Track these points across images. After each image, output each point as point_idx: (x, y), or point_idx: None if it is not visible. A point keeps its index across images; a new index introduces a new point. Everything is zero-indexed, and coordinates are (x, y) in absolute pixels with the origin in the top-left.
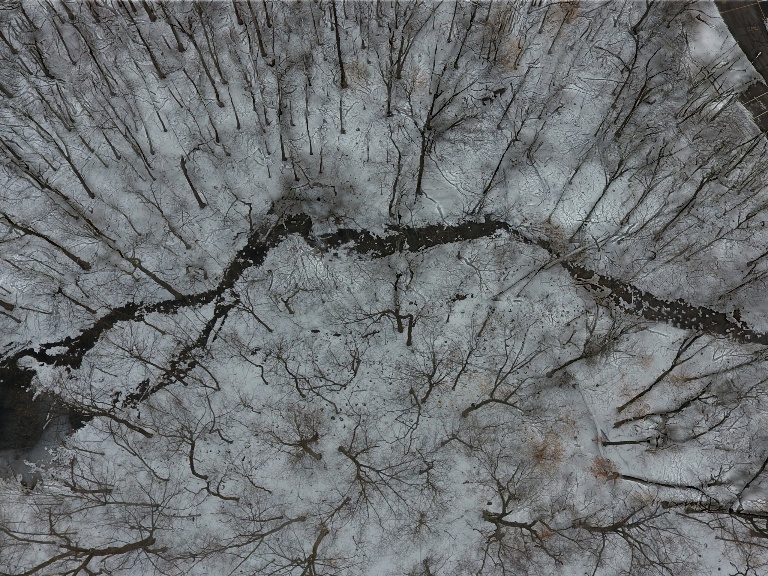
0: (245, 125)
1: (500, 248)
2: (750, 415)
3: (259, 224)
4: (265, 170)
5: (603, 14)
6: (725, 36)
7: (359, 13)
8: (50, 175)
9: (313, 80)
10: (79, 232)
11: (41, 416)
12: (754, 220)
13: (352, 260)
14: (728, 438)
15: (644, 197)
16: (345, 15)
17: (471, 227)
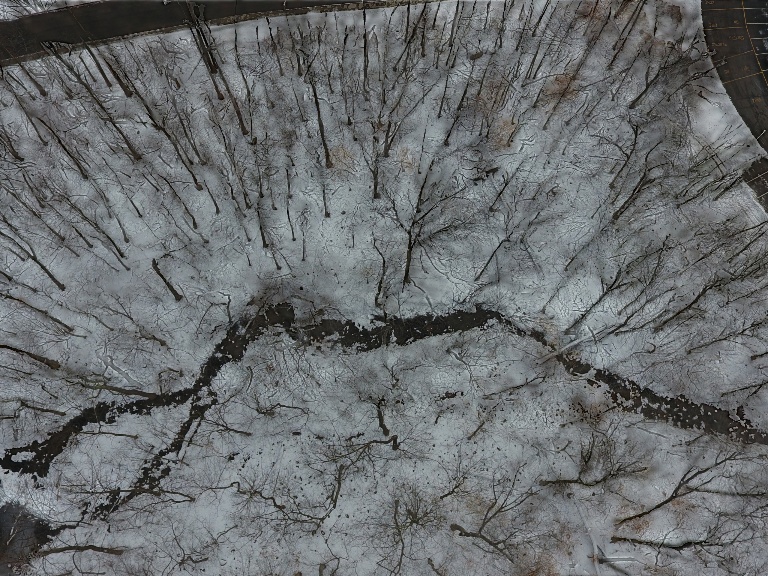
0: (224, 210)
1: (492, 341)
2: (755, 527)
3: (238, 316)
4: (245, 259)
5: (600, 87)
6: (728, 109)
7: (345, 87)
8: (18, 266)
9: (296, 160)
10: (47, 329)
11: (5, 530)
12: (758, 309)
13: (336, 354)
14: (731, 553)
15: (643, 305)
16: (331, 89)
17: (461, 317)
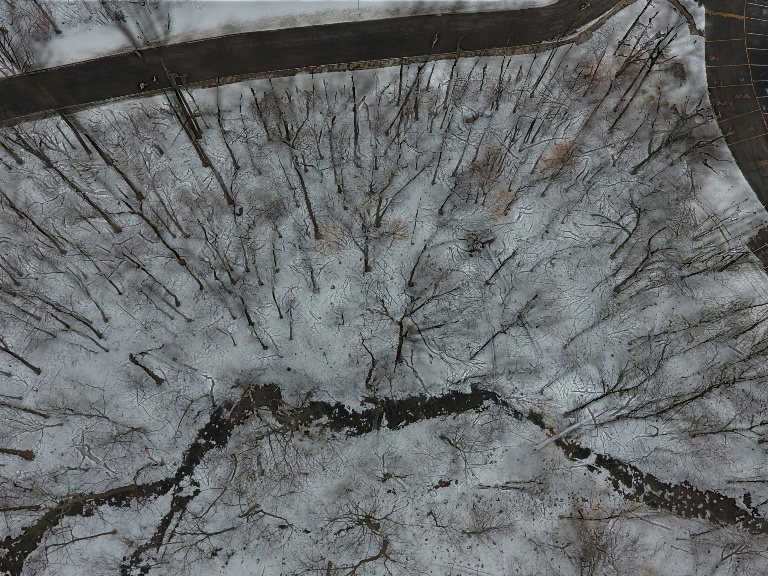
0: (208, 287)
1: (487, 425)
2: None
3: (223, 399)
4: (229, 340)
5: (601, 152)
6: (733, 173)
7: (335, 153)
8: None
9: (284, 232)
10: (21, 418)
11: None
12: (766, 390)
13: (325, 439)
14: None
15: None
16: (320, 155)
17: (456, 398)
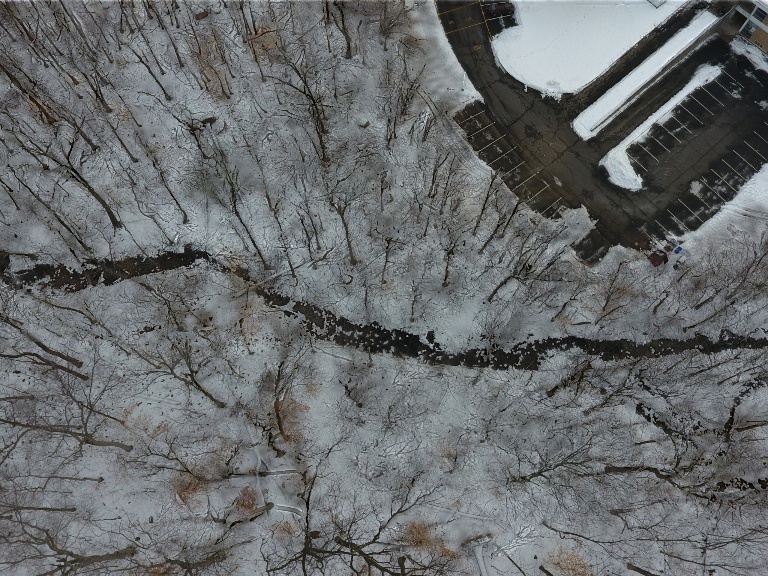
0: None
1: (193, 278)
2: (419, 439)
3: None
4: None
5: (318, 40)
6: (447, 56)
7: (74, 49)
8: None
9: None
10: None
11: None
12: (454, 240)
13: None
14: (394, 463)
15: None
16: (59, 52)
17: (170, 258)
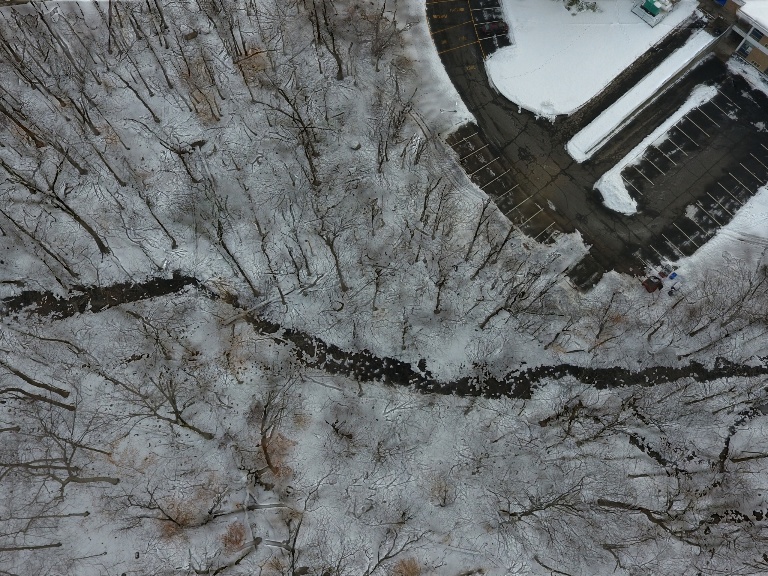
0: None
1: (181, 305)
2: (410, 471)
3: None
4: None
5: (309, 61)
6: (440, 77)
7: (61, 71)
8: None
9: None
10: None
11: None
12: (446, 266)
13: None
14: (385, 496)
15: None
16: (46, 73)
17: (159, 284)
